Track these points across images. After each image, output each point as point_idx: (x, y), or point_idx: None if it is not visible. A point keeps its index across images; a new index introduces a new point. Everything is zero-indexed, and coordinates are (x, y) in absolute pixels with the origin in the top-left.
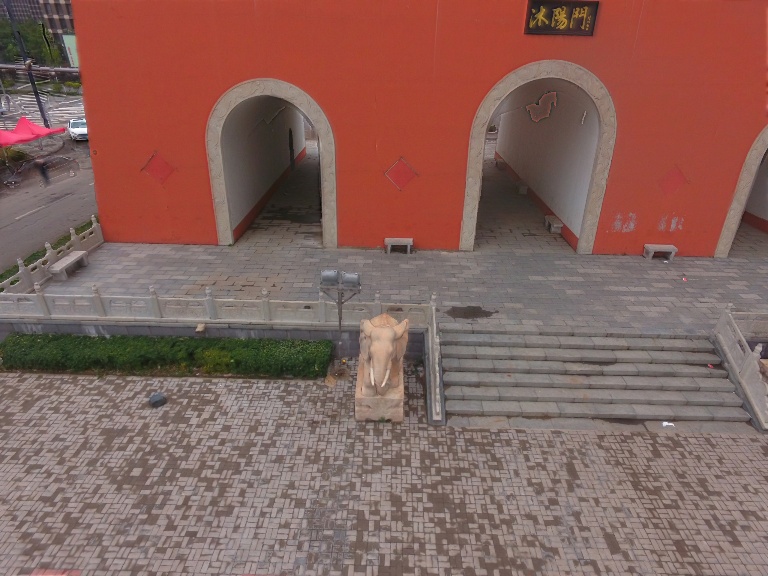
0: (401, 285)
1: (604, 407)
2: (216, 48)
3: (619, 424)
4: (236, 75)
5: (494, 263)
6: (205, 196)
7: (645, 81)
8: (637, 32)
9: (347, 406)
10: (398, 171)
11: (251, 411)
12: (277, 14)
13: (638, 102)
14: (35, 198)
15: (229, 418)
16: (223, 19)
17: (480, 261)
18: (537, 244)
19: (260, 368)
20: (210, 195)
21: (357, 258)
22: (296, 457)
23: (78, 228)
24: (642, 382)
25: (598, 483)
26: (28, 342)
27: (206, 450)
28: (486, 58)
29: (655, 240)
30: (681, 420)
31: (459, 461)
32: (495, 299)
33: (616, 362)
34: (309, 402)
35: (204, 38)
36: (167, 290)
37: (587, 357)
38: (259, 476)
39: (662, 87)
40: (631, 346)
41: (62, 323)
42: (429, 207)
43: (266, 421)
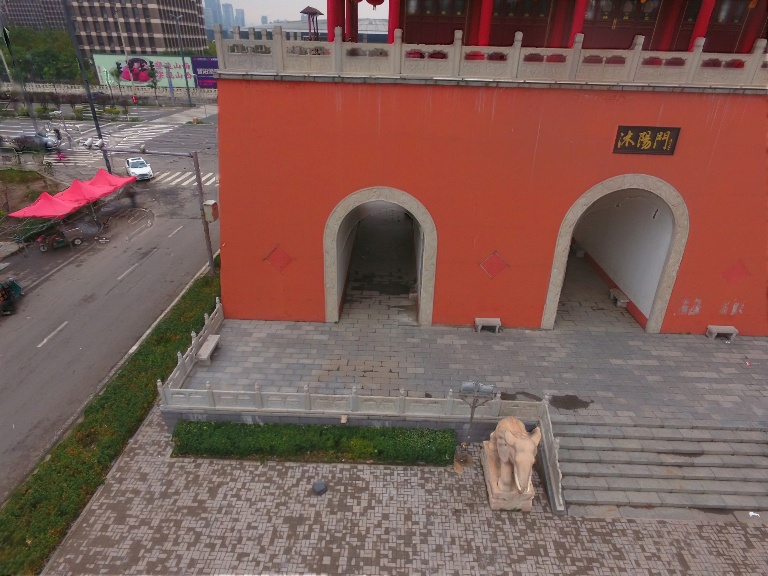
0: (501, 370)
1: (698, 498)
2: (340, 161)
3: (713, 514)
4: (355, 183)
5: (575, 344)
6: (318, 282)
7: (717, 192)
8: (712, 152)
9: (480, 494)
10: (492, 263)
11: (401, 499)
12: (397, 135)
13: (709, 208)
14: (125, 254)
15: (385, 506)
16: (350, 139)
17: (562, 342)
18: (608, 321)
19: (399, 457)
20: (323, 281)
21: (453, 338)
22: (452, 546)
23: (185, 295)
24: (728, 474)
25: (707, 574)
26: (197, 430)
27: (376, 539)
28: (577, 171)
29: (717, 322)
30: (764, 510)
31: (587, 551)
32: (587, 387)
33: (703, 454)
34: (446, 490)
35: (331, 153)
36: (301, 376)
37: (678, 449)
38: (428, 565)
39: (732, 197)
40: (715, 439)
41: (225, 413)
42: (516, 292)
43: (416, 510)
